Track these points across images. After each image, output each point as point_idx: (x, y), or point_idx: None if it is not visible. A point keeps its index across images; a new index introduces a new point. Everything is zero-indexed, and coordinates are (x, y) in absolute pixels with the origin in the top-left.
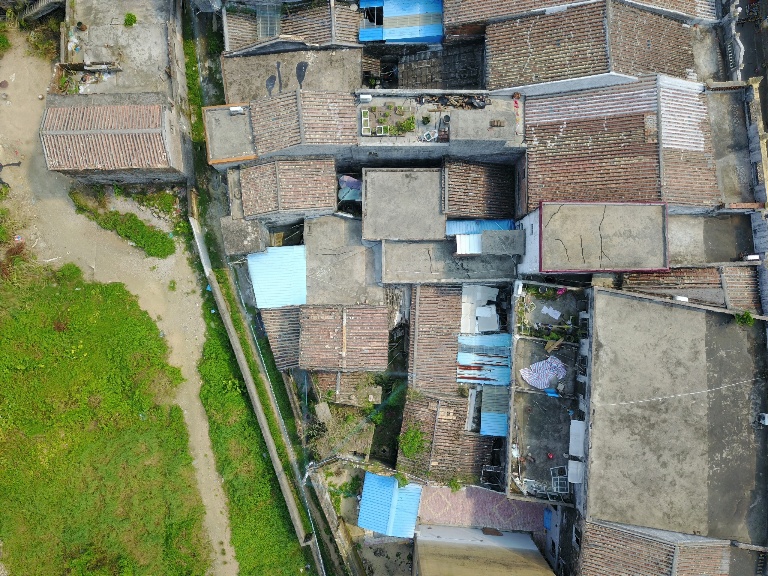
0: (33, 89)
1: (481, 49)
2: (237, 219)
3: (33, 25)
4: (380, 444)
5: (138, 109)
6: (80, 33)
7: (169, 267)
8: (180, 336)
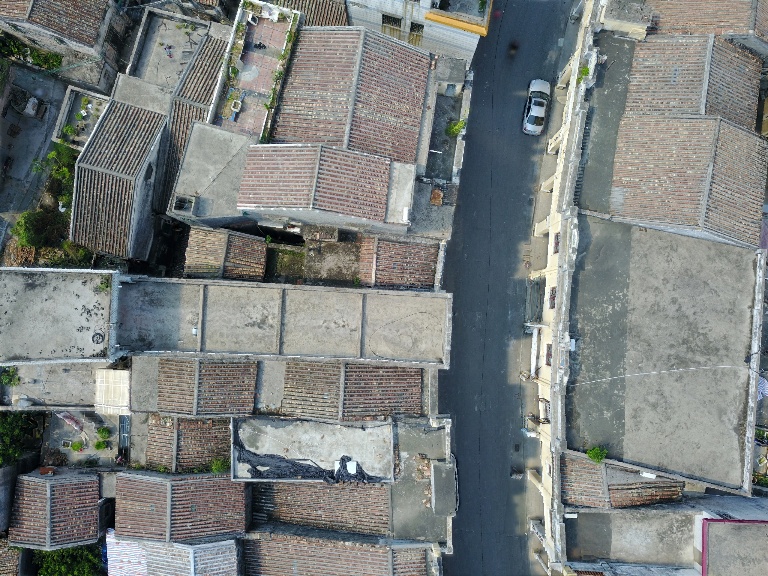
0: None
1: None
2: None
3: None
4: None
5: None
6: None
7: None
8: None
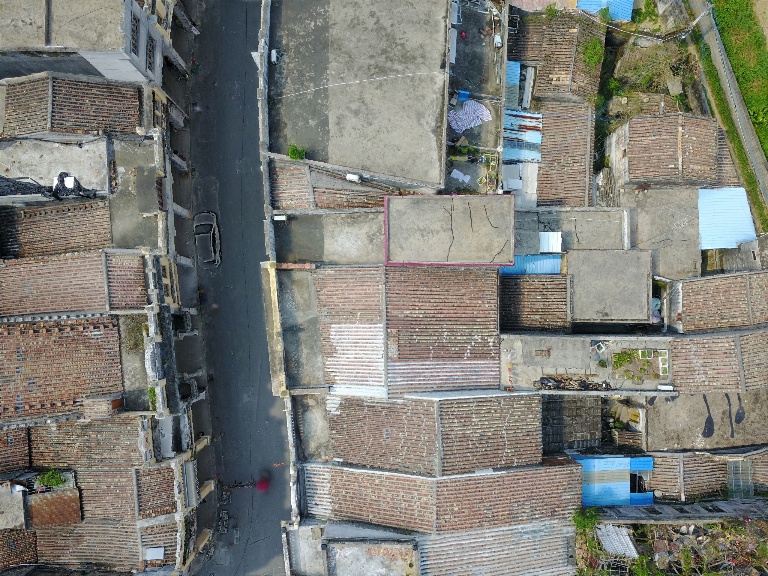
0: None
1: None
2: None
3: None
4: (605, 61)
5: None
6: None
7: None
8: None
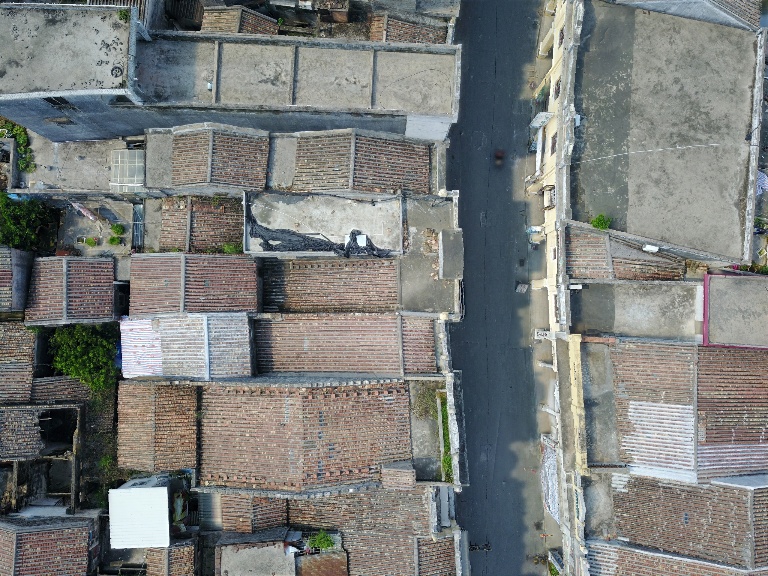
0: None
1: None
2: None
3: None
4: None
5: None
6: None
7: None
8: None
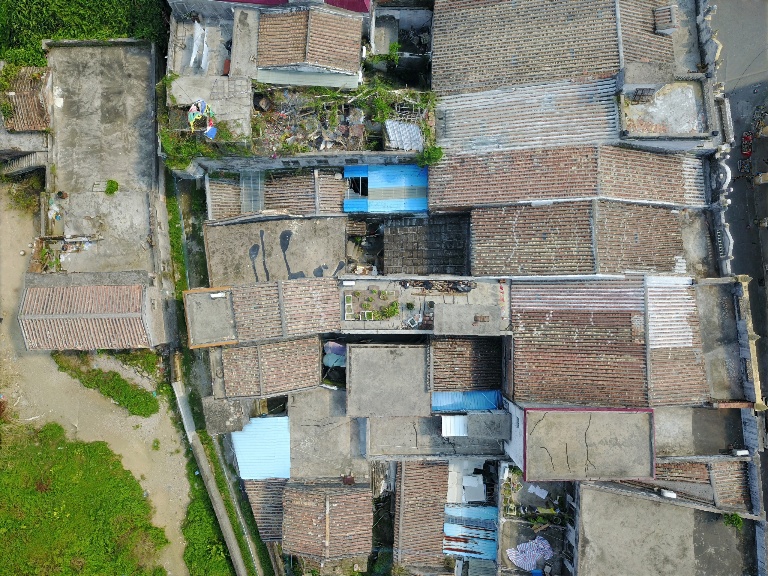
0: (15, 245)
1: (467, 222)
2: (219, 399)
3: (15, 179)
4: None
5: (118, 290)
6: (61, 201)
7: (153, 426)
8: (164, 496)
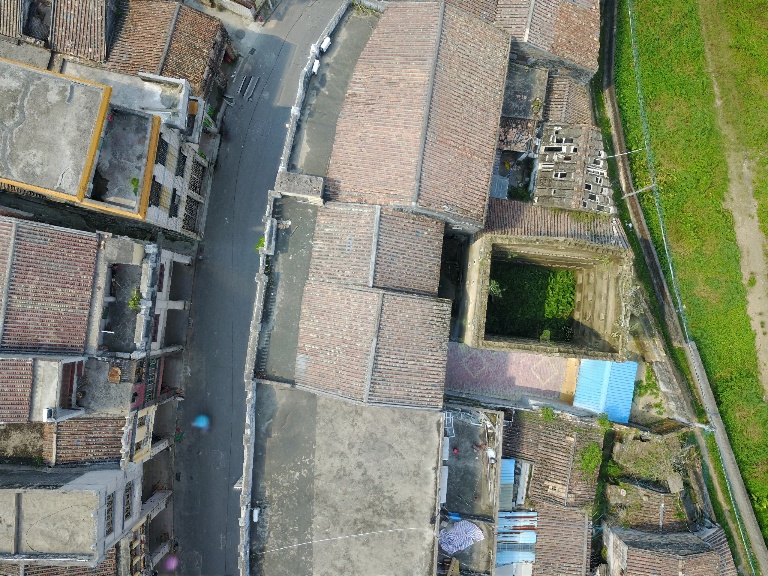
0: None
1: None
2: None
3: None
4: None
5: None
6: None
7: None
8: None
